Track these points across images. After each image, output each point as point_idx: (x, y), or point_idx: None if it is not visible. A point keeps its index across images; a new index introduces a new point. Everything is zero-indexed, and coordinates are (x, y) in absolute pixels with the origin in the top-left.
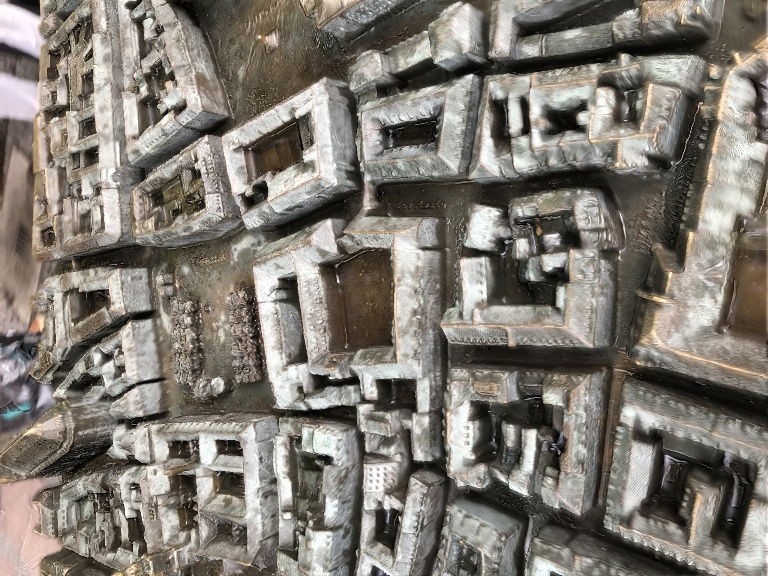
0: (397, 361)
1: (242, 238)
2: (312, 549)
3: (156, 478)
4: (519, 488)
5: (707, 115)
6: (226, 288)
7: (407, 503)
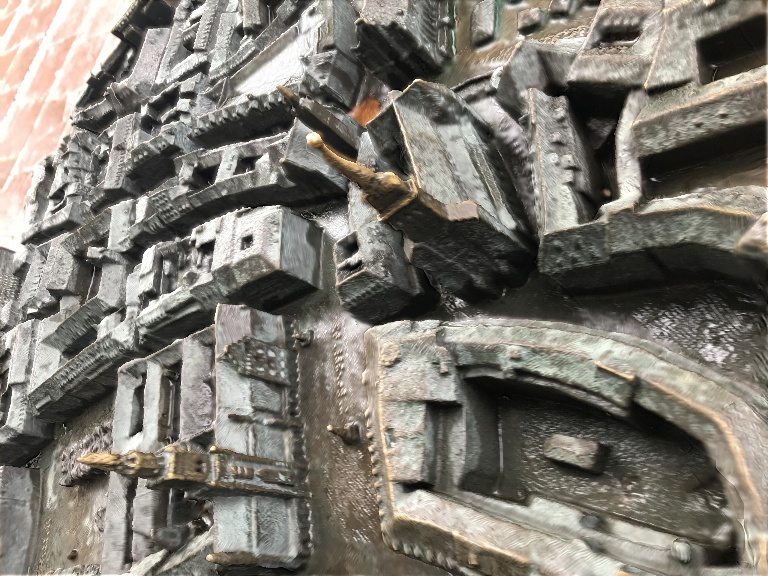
0: (109, 208)
1: (46, 488)
2: (205, 225)
3: (133, 572)
4: (184, 104)
5: (82, 118)
6: (69, 516)
7: (178, 157)
